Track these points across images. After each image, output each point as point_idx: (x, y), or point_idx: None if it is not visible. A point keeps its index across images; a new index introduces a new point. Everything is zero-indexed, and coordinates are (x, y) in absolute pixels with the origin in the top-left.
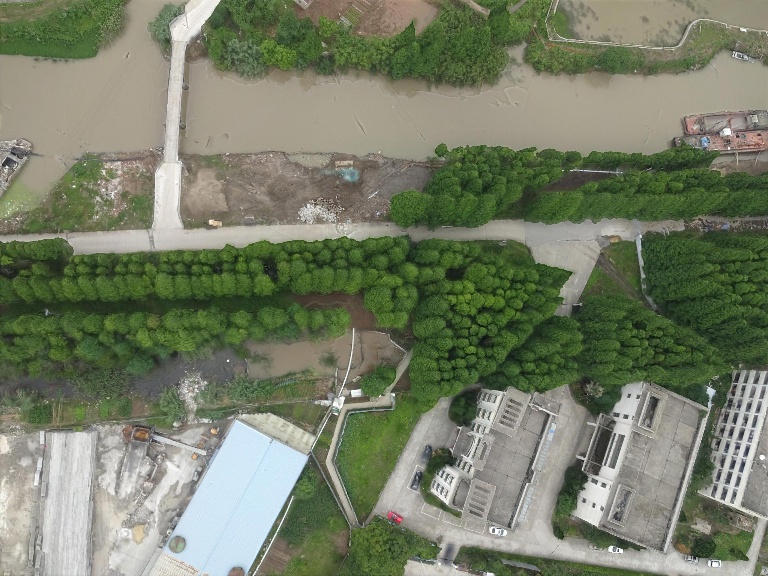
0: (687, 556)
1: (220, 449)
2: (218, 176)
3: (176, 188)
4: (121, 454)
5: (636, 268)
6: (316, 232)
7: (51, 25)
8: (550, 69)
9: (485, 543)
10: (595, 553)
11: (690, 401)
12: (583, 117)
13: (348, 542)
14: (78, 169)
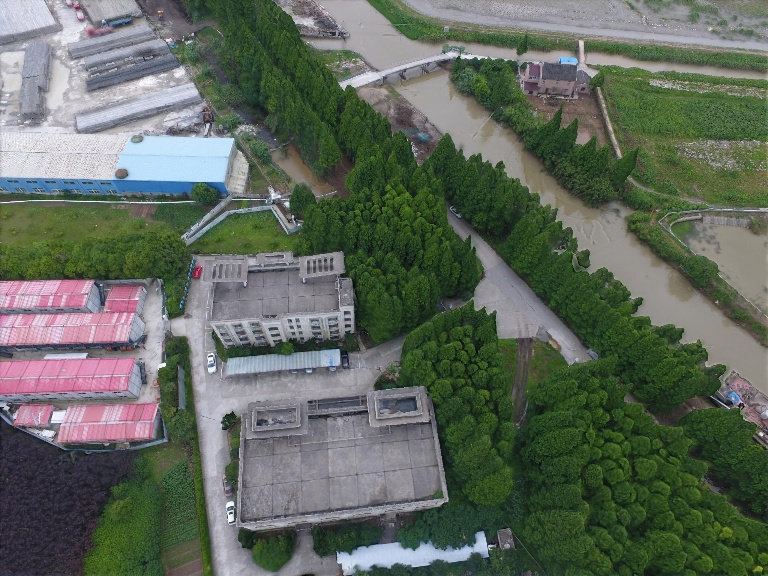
0: None
1: (211, 138)
2: (388, 96)
3: (366, 82)
4: None
5: None
6: None
7: (413, 21)
8: (639, 233)
9: (196, 358)
10: (219, 488)
11: (441, 465)
12: (637, 293)
13: None
14: None
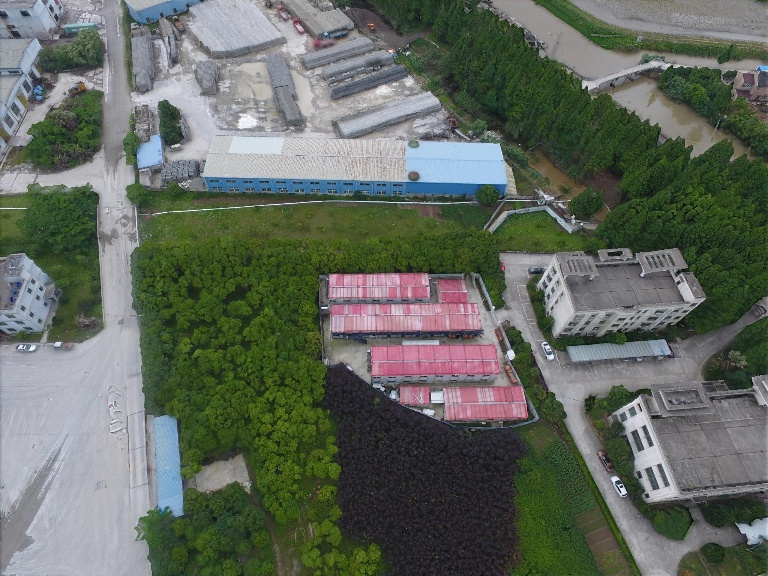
0: None
1: (478, 143)
2: None
3: None
4: None
5: None
6: None
7: None
8: None
9: None
10: (598, 464)
11: None
12: None
13: None
14: (554, 60)
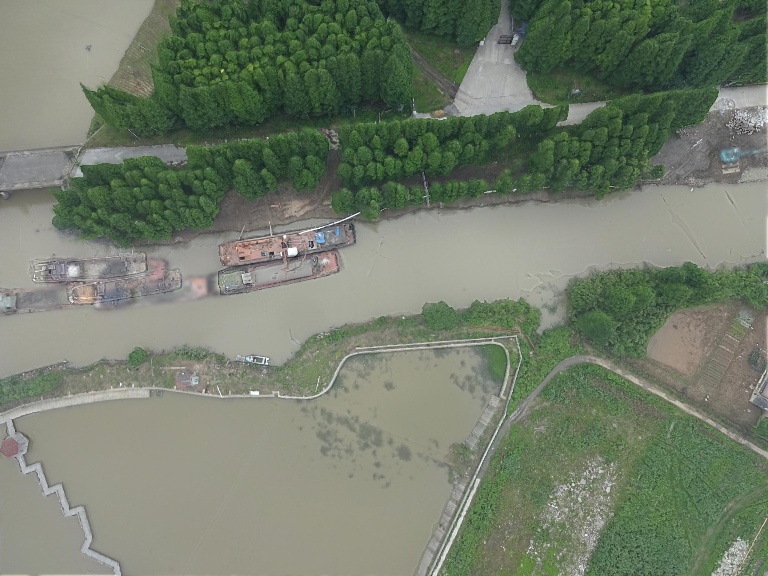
0: None
1: None
2: None
3: None
4: None
5: (414, 84)
6: (753, 99)
7: None
8: None
9: None
10: None
11: None
12: (452, 268)
13: None
14: None
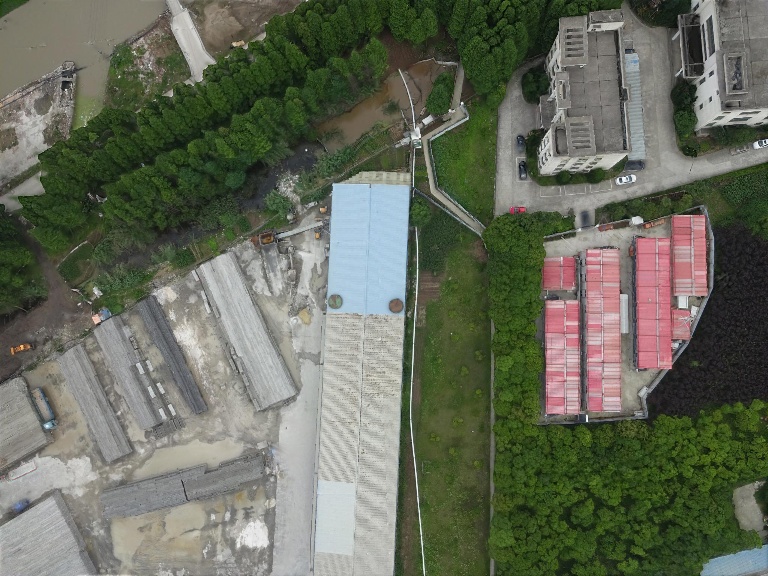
0: None
1: (331, 213)
2: (221, 5)
3: (193, 32)
4: (260, 262)
5: None
6: None
7: None
8: None
9: (618, 197)
10: (741, 157)
11: None
12: None
13: (485, 249)
14: (114, 61)
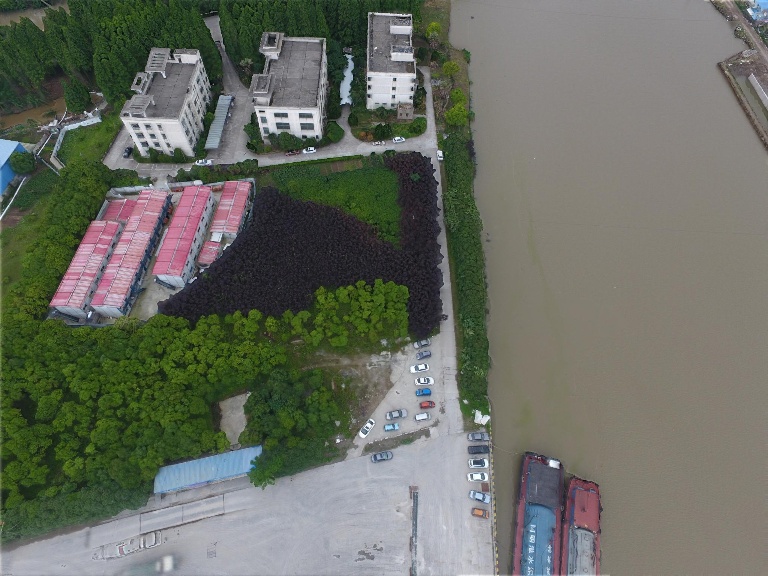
0: (374, 143)
1: None
2: None
3: None
4: None
5: None
6: None
7: None
8: None
9: None
10: (293, 158)
11: (308, 38)
12: None
13: None
14: None
